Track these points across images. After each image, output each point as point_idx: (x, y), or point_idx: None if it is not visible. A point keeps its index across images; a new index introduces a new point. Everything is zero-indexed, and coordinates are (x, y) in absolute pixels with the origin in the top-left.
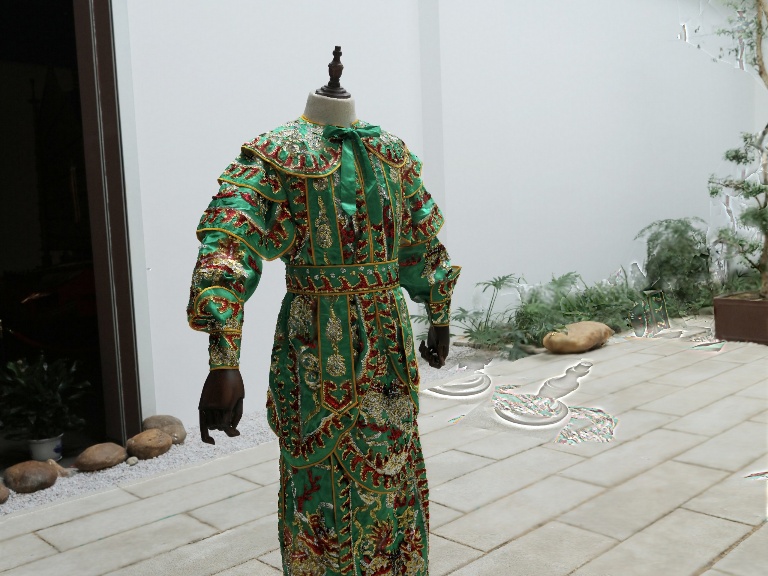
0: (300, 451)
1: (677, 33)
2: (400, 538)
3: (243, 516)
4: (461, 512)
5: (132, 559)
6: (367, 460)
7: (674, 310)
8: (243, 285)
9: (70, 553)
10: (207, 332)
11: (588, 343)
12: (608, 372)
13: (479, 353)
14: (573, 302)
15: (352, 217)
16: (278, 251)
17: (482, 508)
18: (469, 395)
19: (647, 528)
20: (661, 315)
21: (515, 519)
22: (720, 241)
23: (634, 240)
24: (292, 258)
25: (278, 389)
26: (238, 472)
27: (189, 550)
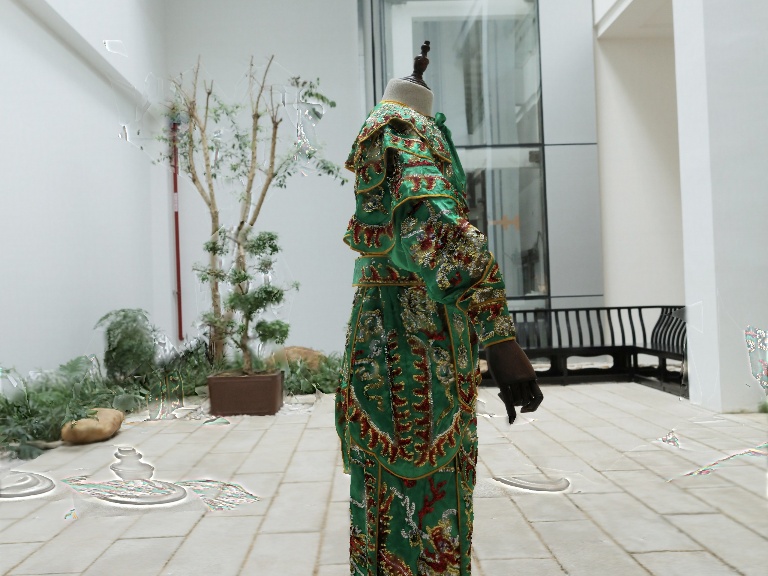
0: (427, 457)
1: (118, 132)
2: None
3: None
4: None
5: None
6: (469, 458)
7: (191, 388)
8: None
9: None
10: (459, 306)
11: (112, 429)
12: (161, 451)
13: None
14: (78, 389)
15: None
16: None
17: (242, 575)
18: (44, 492)
19: None
20: (176, 394)
21: (288, 574)
22: (208, 324)
23: (93, 330)
24: None
25: None
26: None
27: None
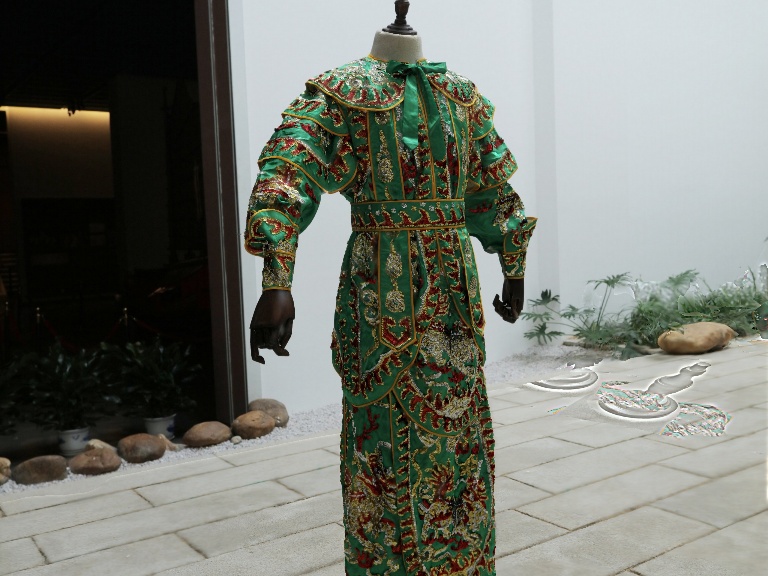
0: (359, 389)
1: None
2: (462, 486)
3: (329, 485)
4: (549, 493)
5: (219, 516)
6: (426, 401)
7: None
8: (299, 211)
9: (163, 508)
10: None
11: (707, 344)
12: (727, 372)
13: (590, 353)
14: (692, 302)
15: (414, 152)
16: (339, 185)
17: (572, 490)
18: (573, 389)
19: (751, 518)
20: None
21: (606, 502)
22: None
23: None
24: (356, 196)
25: (340, 327)
26: (330, 448)
27: (273, 512)
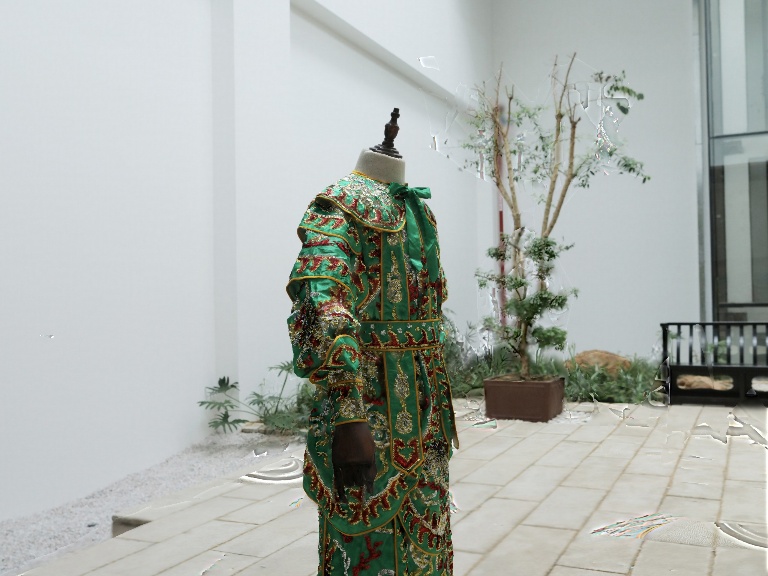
0: (360, 516)
1: (428, 143)
2: None
3: None
4: None
5: None
6: (424, 521)
7: (458, 391)
8: None
9: None
10: None
11: None
12: None
13: (272, 439)
14: None
15: (417, 273)
16: None
17: None
18: (293, 479)
19: None
20: None
21: None
22: (487, 328)
23: None
24: None
25: None
26: None
27: None
